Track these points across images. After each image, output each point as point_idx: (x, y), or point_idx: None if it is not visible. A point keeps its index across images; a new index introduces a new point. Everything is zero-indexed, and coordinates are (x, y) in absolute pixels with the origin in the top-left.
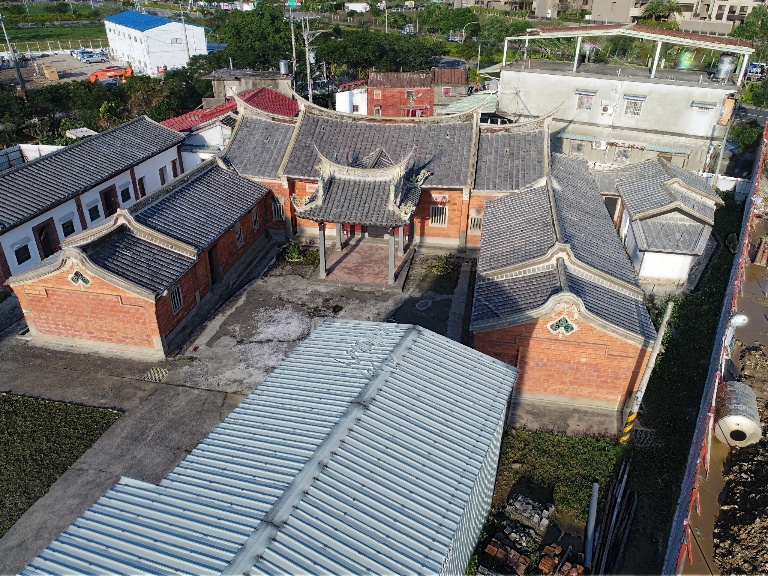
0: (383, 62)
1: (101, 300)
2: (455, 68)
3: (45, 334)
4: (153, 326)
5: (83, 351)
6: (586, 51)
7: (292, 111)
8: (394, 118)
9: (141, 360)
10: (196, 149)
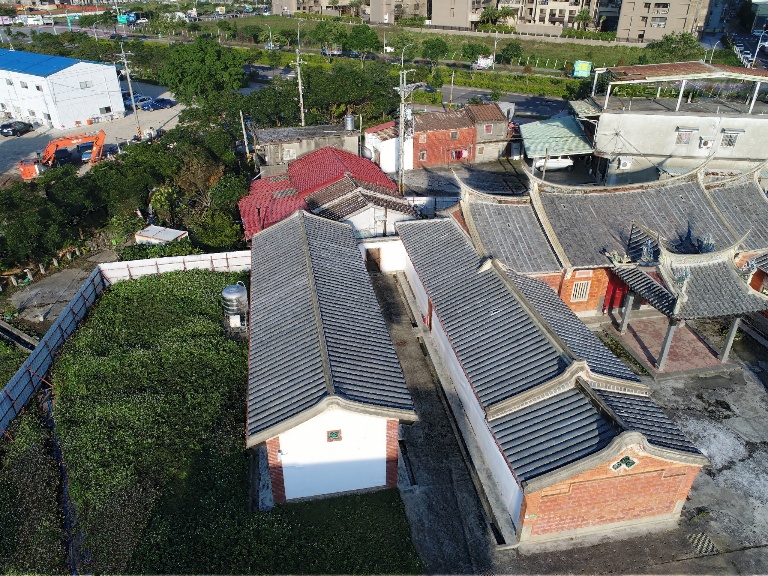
0: (376, 98)
1: (637, 479)
2: (486, 104)
3: (540, 535)
4: (684, 490)
5: (592, 541)
6: (690, 92)
7: (379, 172)
8: (624, 186)
9: (662, 530)
10: (359, 239)
